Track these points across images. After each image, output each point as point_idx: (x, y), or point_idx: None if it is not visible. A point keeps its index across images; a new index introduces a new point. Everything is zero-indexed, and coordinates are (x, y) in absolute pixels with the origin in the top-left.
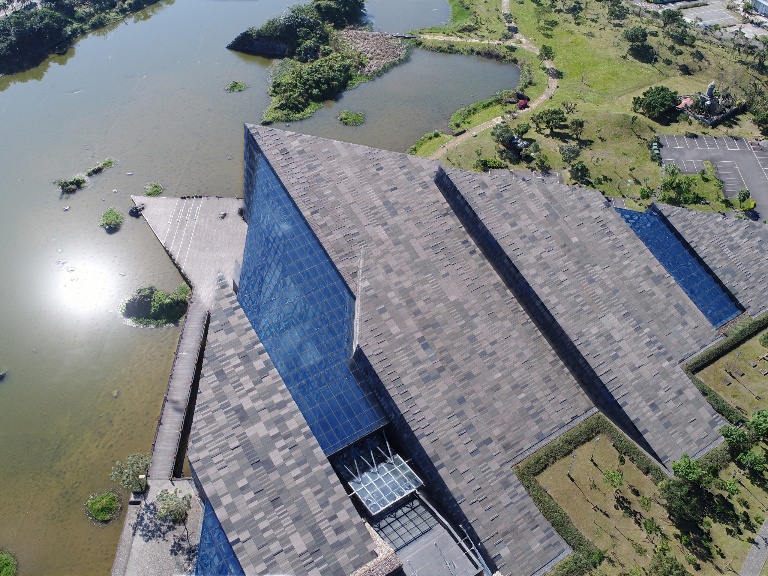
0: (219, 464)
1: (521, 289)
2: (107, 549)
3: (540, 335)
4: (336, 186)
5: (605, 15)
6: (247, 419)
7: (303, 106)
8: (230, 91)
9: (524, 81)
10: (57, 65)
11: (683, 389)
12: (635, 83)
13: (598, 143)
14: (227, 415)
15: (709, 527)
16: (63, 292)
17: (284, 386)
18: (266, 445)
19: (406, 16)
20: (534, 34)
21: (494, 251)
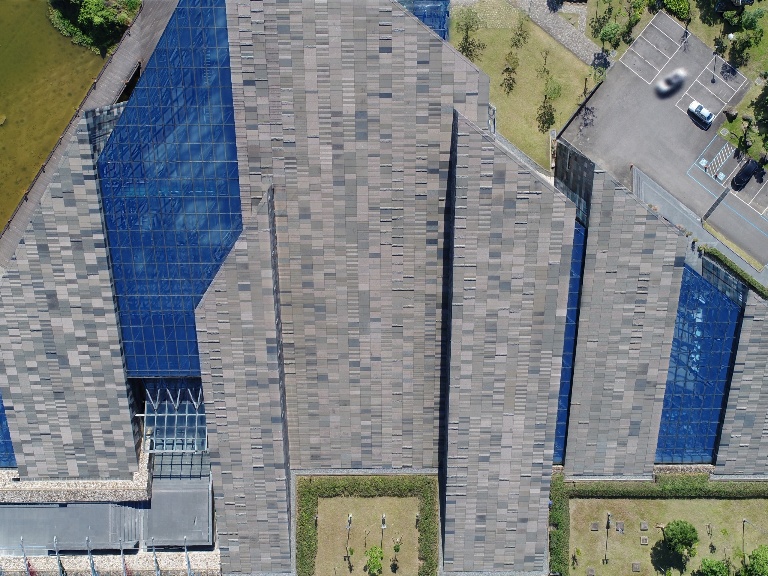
0: (14, 337)
1: None
2: None
3: (437, 376)
4: (303, 51)
5: None
6: (57, 309)
7: None
8: None
9: None
10: None
11: (530, 519)
12: None
13: None
14: (37, 295)
15: None
16: None
17: (110, 294)
18: (68, 342)
19: None
20: None
21: (451, 265)
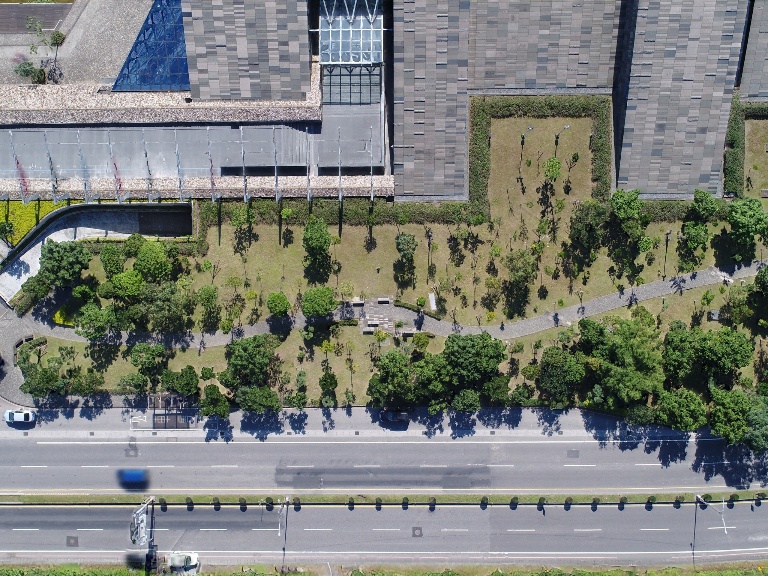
0: None
1: None
2: None
3: None
4: None
5: None
6: None
7: None
8: None
9: None
10: None
11: (710, 129)
12: None
13: None
14: None
15: None
16: None
17: None
18: None
19: None
20: None
21: None
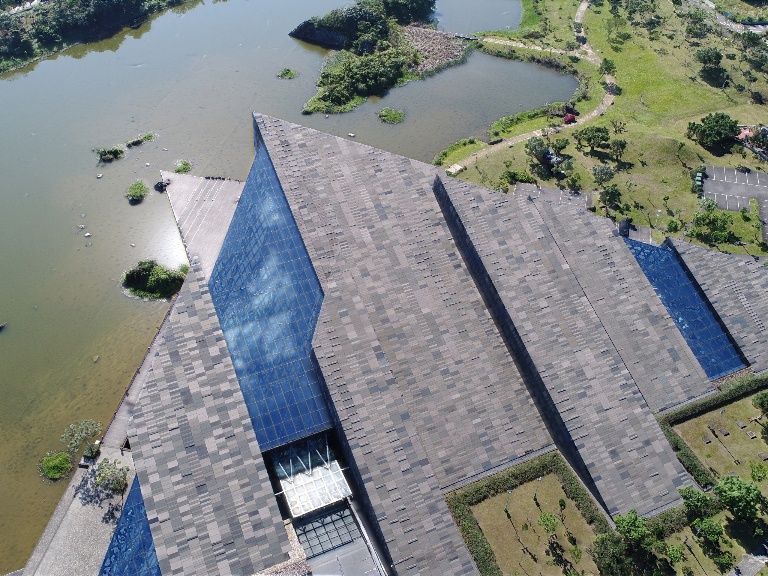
0: (154, 442)
1: (498, 311)
2: (49, 506)
3: (511, 361)
4: (330, 183)
5: (683, 32)
6: (191, 403)
7: (346, 99)
8: (281, 78)
9: (578, 94)
10: (132, 38)
11: (651, 440)
12: (698, 107)
13: (638, 167)
14: (172, 396)
15: None
16: (75, 255)
17: (234, 375)
18: (204, 431)
19: (475, 17)
20: (602, 46)
21: (478, 268)
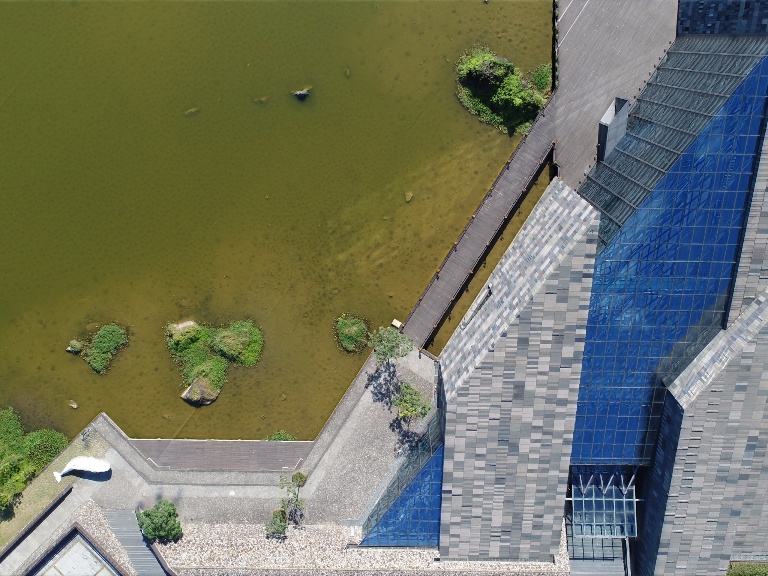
0: (471, 425)
1: None
2: (340, 379)
3: None
4: None
5: None
6: (521, 399)
7: None
8: None
9: None
10: None
11: None
12: None
13: None
14: (505, 386)
15: None
16: None
17: (577, 386)
18: (523, 431)
19: None
20: None
21: None
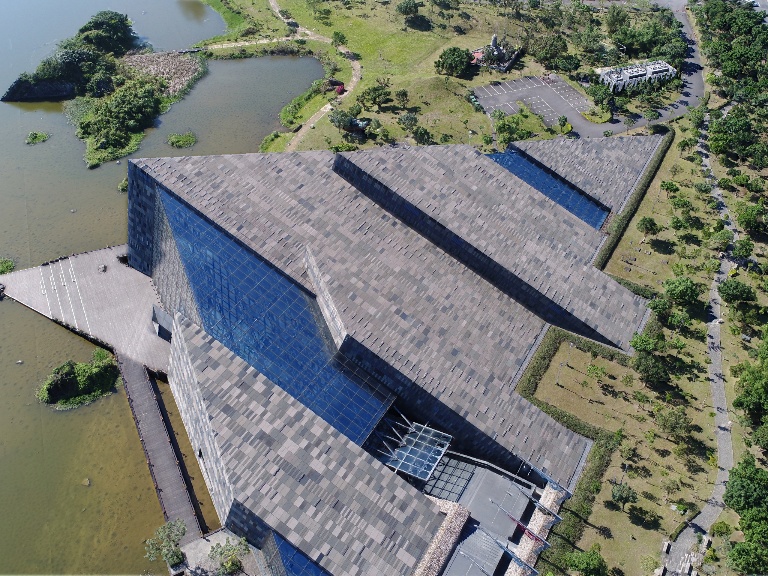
0: (269, 494)
1: (450, 243)
2: None
3: (480, 278)
4: (248, 198)
5: None
6: (274, 442)
7: (125, 140)
8: (32, 144)
9: (330, 69)
10: None
11: (605, 284)
12: (425, 50)
13: (425, 108)
14: (253, 445)
15: (679, 380)
16: None
17: (292, 398)
18: (303, 459)
19: (181, 31)
20: (315, 25)
21: (414, 217)
